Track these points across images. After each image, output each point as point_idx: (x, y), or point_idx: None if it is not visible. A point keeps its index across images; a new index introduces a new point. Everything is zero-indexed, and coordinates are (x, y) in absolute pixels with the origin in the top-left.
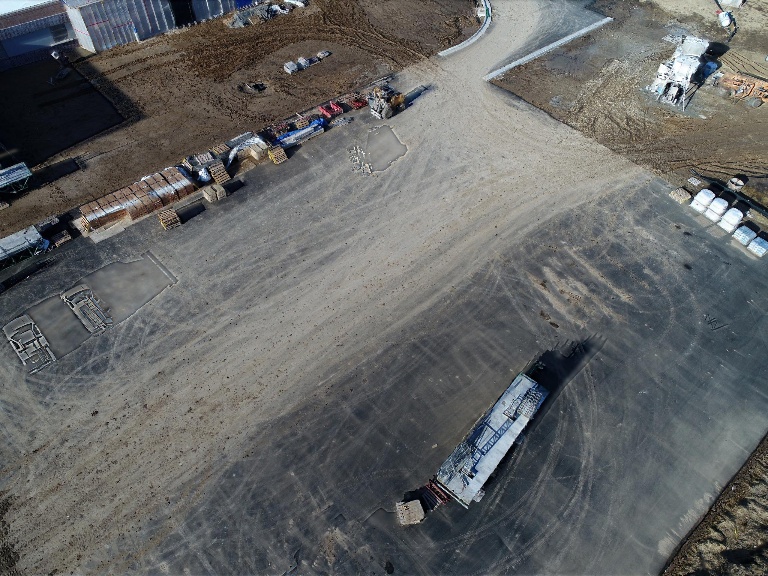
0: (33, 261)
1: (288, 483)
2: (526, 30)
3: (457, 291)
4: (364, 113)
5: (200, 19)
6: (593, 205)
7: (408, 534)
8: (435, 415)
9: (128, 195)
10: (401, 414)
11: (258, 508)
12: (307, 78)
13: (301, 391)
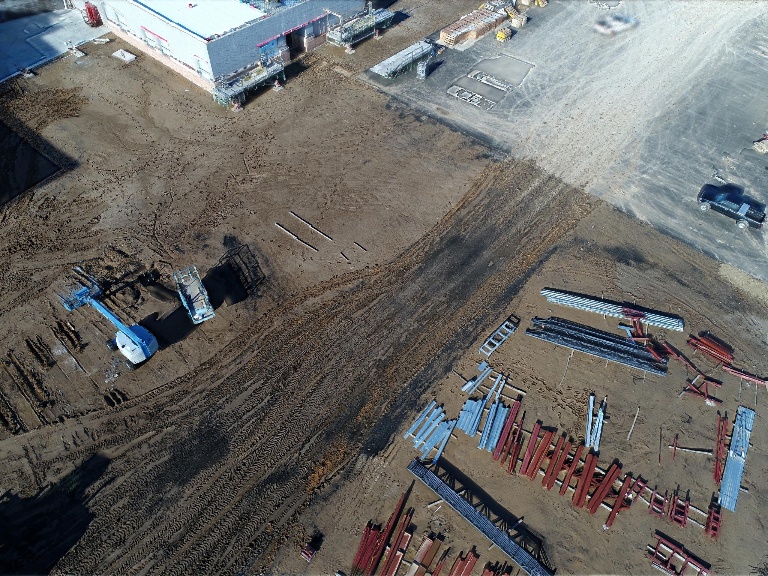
0: (431, 62)
1: (685, 142)
2: None
3: (714, 59)
4: None
5: None
6: (766, 16)
7: (767, 156)
8: (744, 111)
9: (467, 23)
10: (725, 112)
11: (677, 152)
12: None
13: (659, 106)
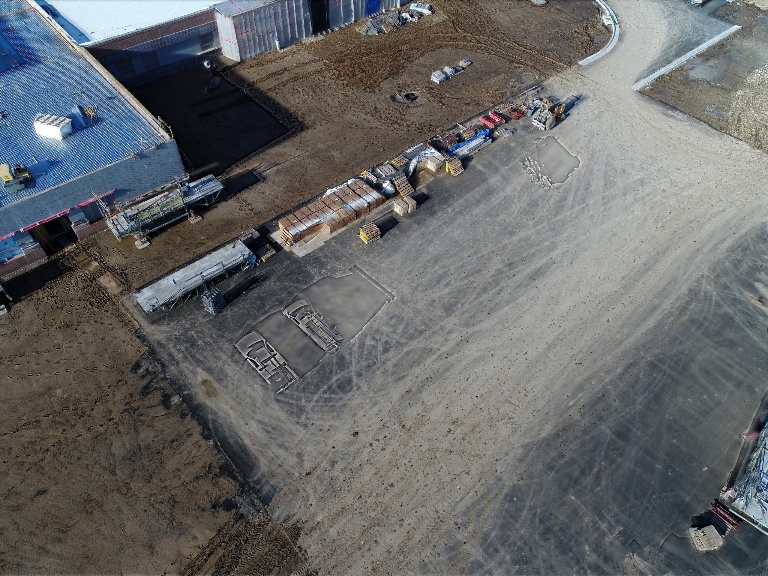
0: (244, 276)
1: (571, 507)
2: (658, 39)
3: (677, 307)
4: (524, 123)
5: (333, 27)
6: None
7: (708, 561)
8: (695, 436)
9: (323, 208)
10: (661, 435)
11: (550, 533)
12: (456, 87)
13: (554, 411)
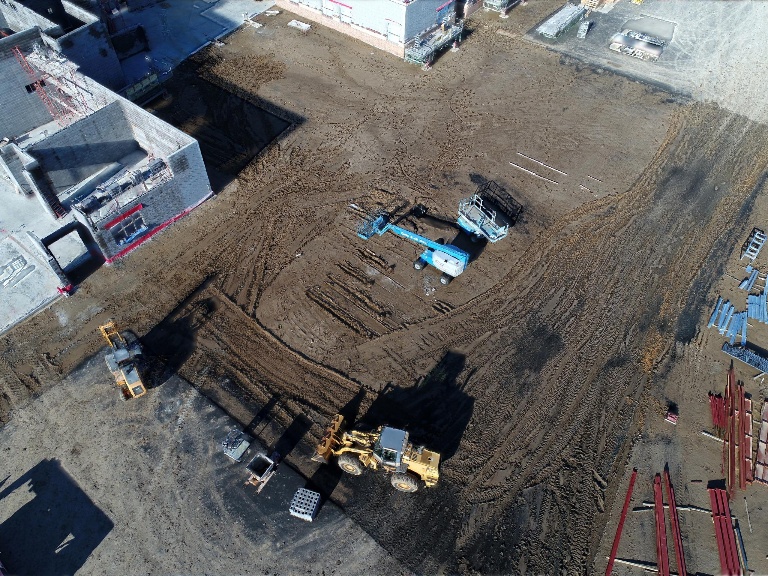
0: None
1: None
2: None
3: None
4: None
5: None
6: None
7: None
8: None
9: None
10: None
11: None
12: None
13: None
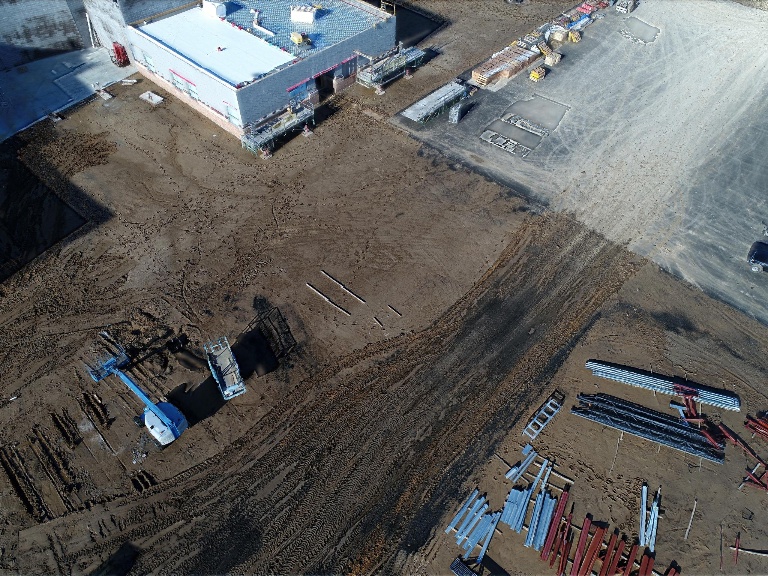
0: (463, 104)
1: (731, 194)
2: None
3: (758, 100)
4: (610, 11)
5: None
6: None
7: None
8: None
9: (499, 62)
10: None
11: (724, 205)
12: None
13: (702, 153)
